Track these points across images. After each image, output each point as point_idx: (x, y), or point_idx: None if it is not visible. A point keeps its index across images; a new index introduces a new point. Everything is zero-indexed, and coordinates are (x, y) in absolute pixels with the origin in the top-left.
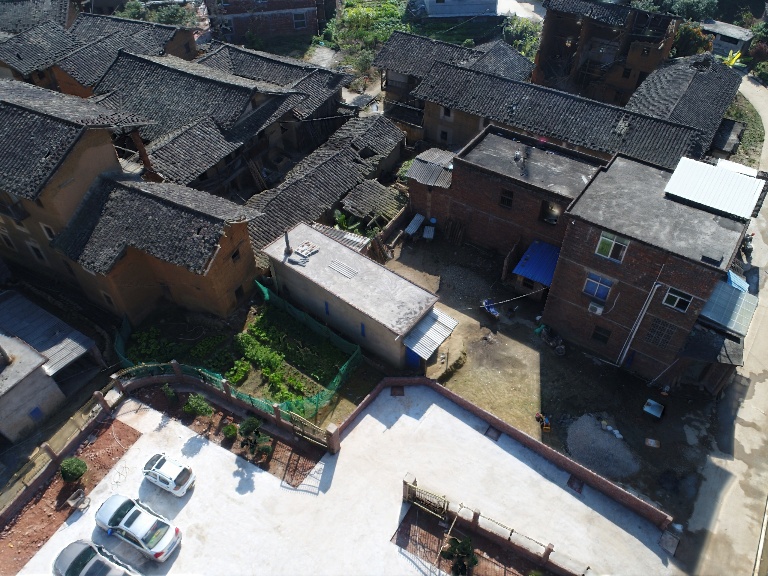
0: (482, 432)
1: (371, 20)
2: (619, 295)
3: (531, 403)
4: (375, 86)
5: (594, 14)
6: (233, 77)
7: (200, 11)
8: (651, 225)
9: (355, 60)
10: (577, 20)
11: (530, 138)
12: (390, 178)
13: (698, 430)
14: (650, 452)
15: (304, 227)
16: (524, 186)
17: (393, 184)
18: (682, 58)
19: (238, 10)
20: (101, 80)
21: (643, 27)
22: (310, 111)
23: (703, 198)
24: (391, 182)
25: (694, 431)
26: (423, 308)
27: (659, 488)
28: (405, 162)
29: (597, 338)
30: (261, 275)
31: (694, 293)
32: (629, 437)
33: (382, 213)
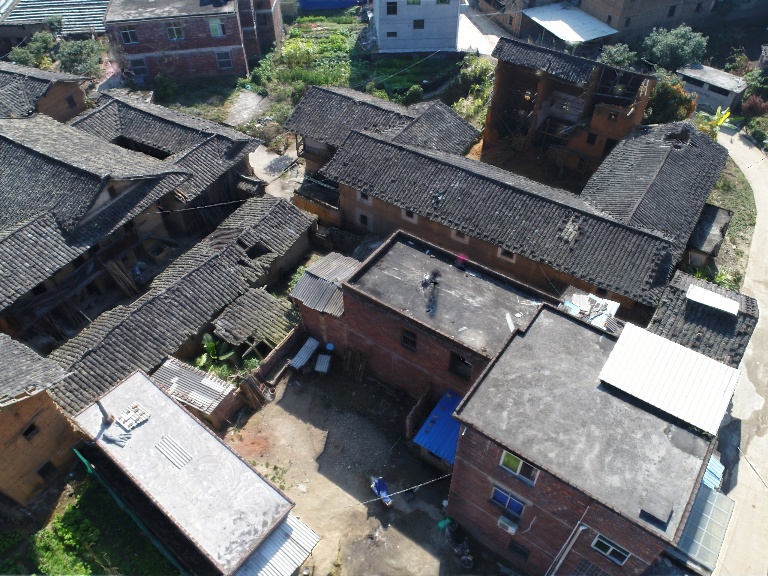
0: None
1: (315, 54)
2: (535, 519)
3: None
4: None
5: (552, 68)
6: (105, 148)
7: None
8: (573, 441)
9: None
10: (533, 74)
11: (447, 252)
12: None
13: None
14: None
15: (139, 379)
16: (427, 331)
17: None
18: (656, 125)
19: (150, 48)
20: None
21: (611, 84)
22: (198, 190)
23: (652, 394)
24: None
25: None
26: (268, 524)
27: None
28: (299, 268)
29: (515, 549)
30: (83, 441)
31: (632, 550)
32: None
33: (265, 337)
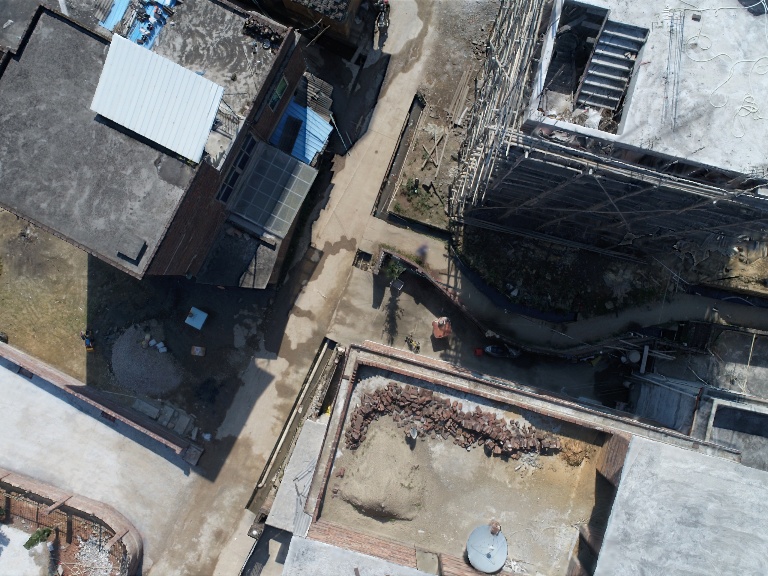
0: (15, 371)
1: None
2: None
3: (76, 318)
4: None
5: None
6: None
7: None
8: (65, 187)
9: None
10: None
11: None
12: None
13: (248, 329)
14: (194, 362)
15: None
16: None
17: None
18: None
19: None
20: None
21: None
22: None
23: (141, 124)
24: None
25: (243, 331)
26: None
27: (196, 400)
28: None
29: None
30: None
31: None
32: (175, 347)
33: None
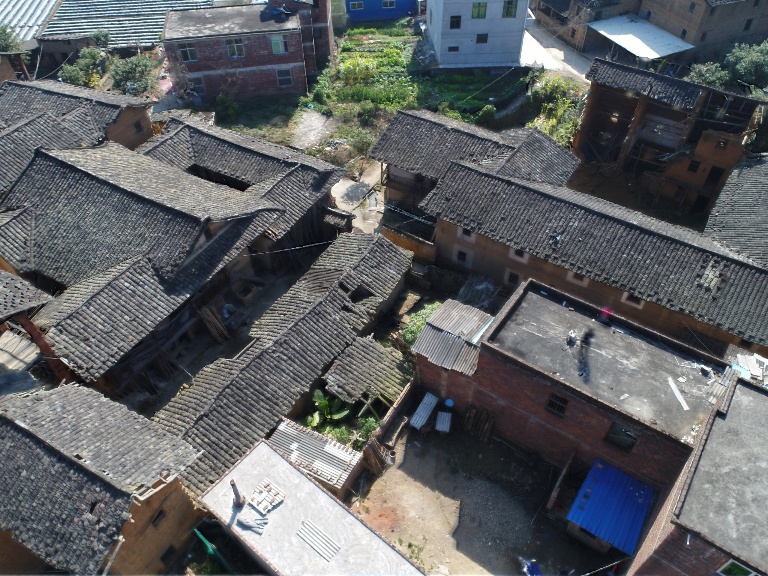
0: None
1: None
2: None
3: None
4: (374, 169)
5: (654, 92)
6: (187, 181)
7: (164, 66)
8: None
9: (350, 131)
10: (630, 97)
11: (588, 305)
12: (391, 320)
13: None
14: None
15: (265, 450)
16: (586, 399)
17: (395, 332)
18: None
19: (209, 66)
20: (10, 190)
21: (717, 109)
22: (287, 226)
23: None
24: (392, 327)
25: None
26: None
27: None
28: (411, 315)
29: None
30: (203, 518)
31: None
32: None
33: (379, 393)
